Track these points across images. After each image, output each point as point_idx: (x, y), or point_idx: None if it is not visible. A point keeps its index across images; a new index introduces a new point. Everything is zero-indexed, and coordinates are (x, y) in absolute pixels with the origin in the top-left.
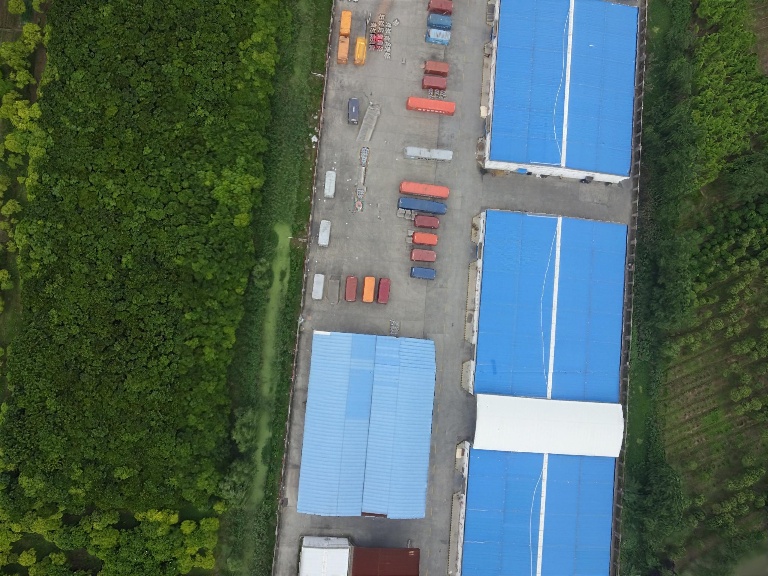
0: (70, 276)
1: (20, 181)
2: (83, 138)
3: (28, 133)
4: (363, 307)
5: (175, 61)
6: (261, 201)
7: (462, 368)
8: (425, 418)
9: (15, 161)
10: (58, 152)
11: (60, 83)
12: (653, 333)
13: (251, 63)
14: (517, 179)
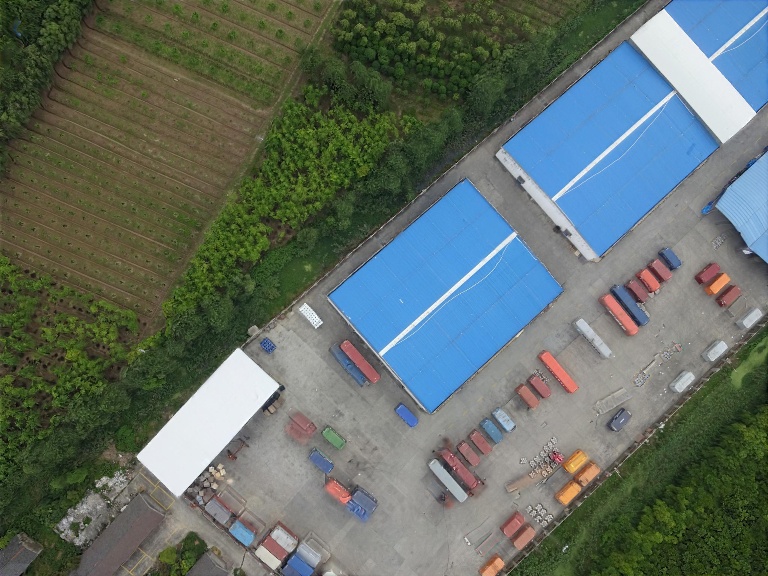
0: None
1: None
2: None
3: None
4: None
5: (738, 569)
6: None
7: (696, 172)
8: (764, 164)
9: None
10: None
11: None
12: None
13: (680, 521)
14: None
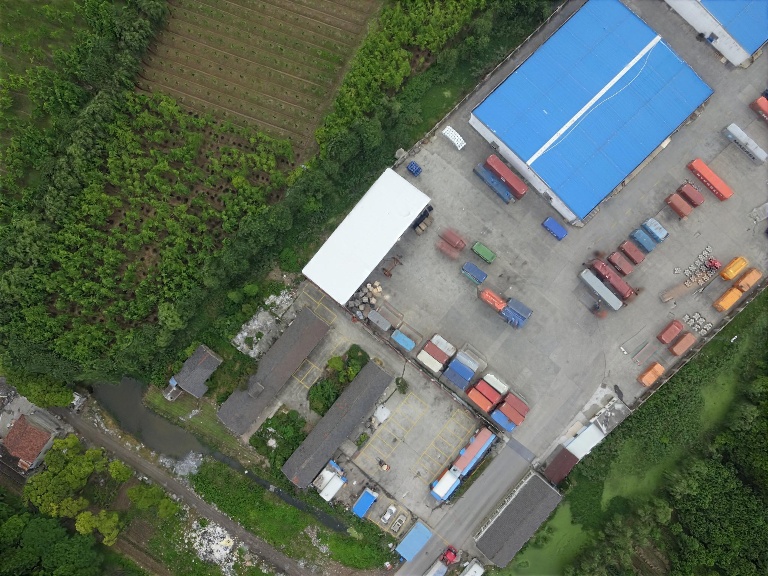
0: None
1: None
2: None
3: None
4: None
5: None
6: None
7: None
8: None
9: None
10: None
11: None
12: None
13: None
14: None
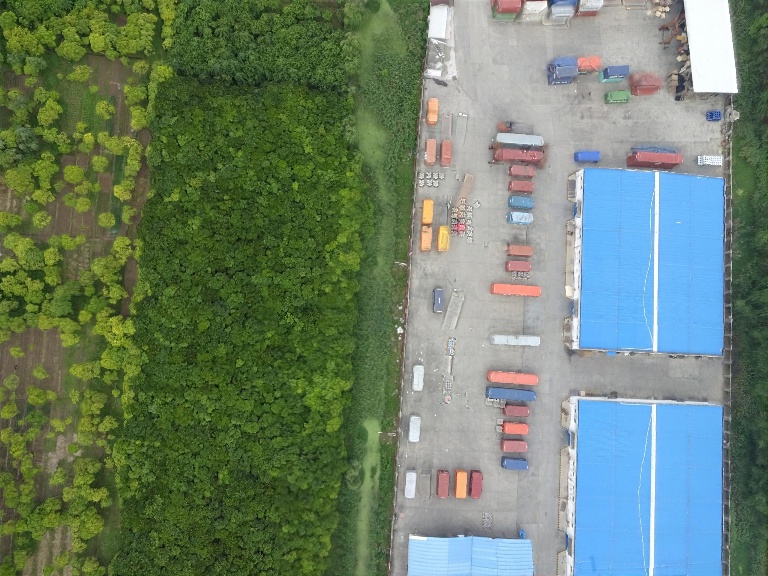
0: (169, 496)
1: (115, 395)
2: (177, 355)
3: (123, 350)
4: (455, 500)
5: (264, 271)
6: (351, 400)
7: (557, 559)
8: None
9: (111, 378)
10: (153, 370)
11: (153, 301)
12: (752, 512)
13: (338, 265)
14: (605, 358)
